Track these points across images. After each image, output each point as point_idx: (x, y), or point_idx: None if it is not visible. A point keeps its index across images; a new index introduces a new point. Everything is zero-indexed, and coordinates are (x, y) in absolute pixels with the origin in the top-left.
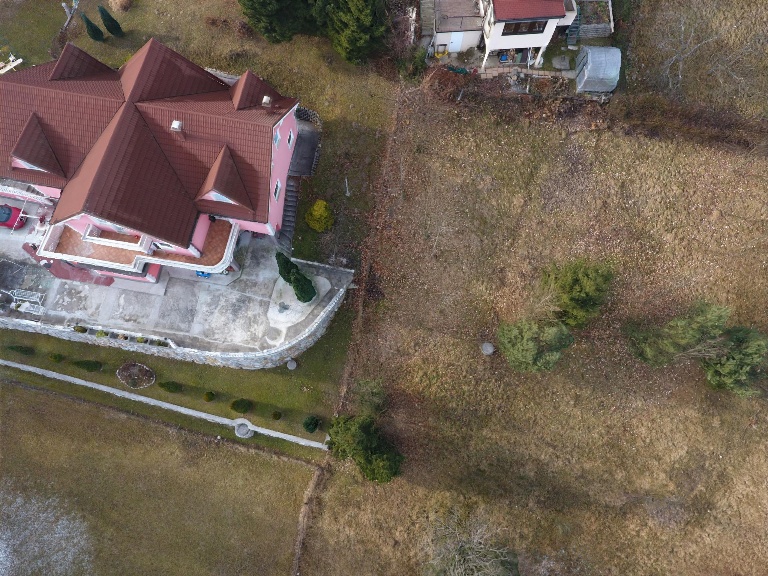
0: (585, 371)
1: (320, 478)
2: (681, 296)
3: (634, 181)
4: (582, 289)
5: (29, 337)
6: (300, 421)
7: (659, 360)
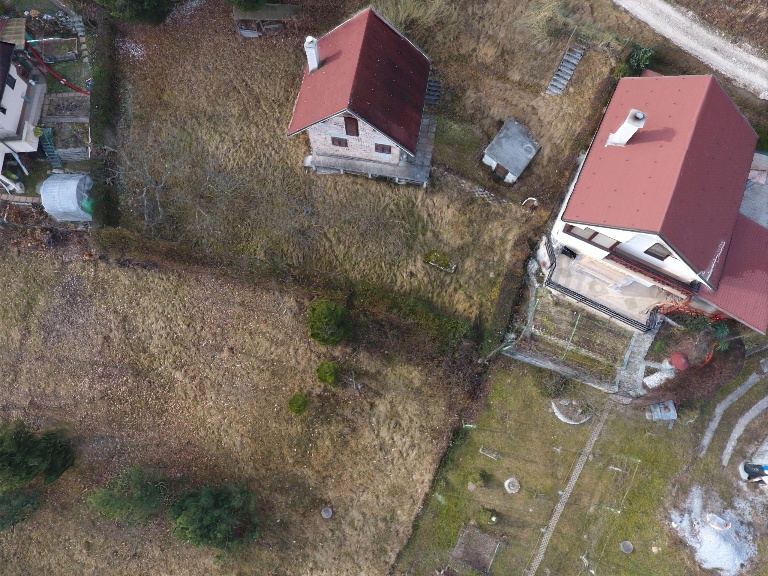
0: (96, 518)
1: None
2: (197, 438)
3: (136, 315)
4: None
5: None
6: None
7: None
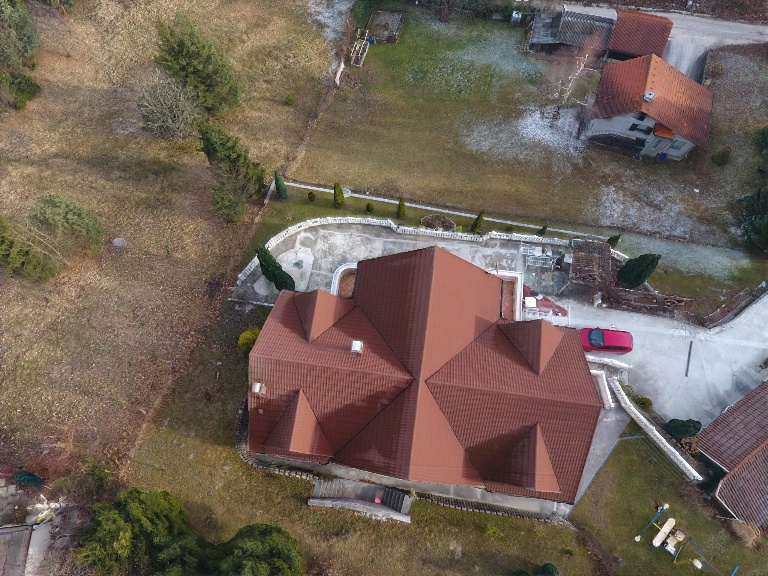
0: None
1: None
2: None
3: None
4: None
5: None
6: (295, 197)
7: None
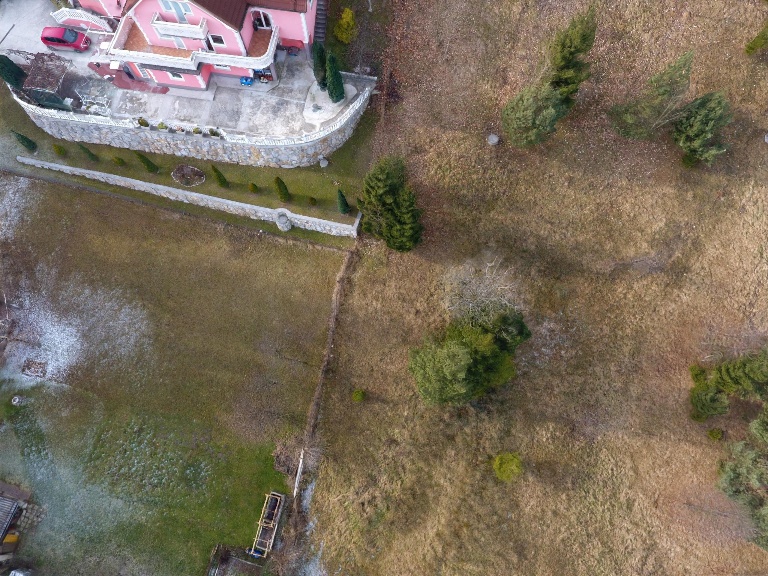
0: (577, 156)
1: (350, 261)
2: None
3: None
4: (572, 43)
5: (93, 148)
6: (332, 209)
7: (639, 131)
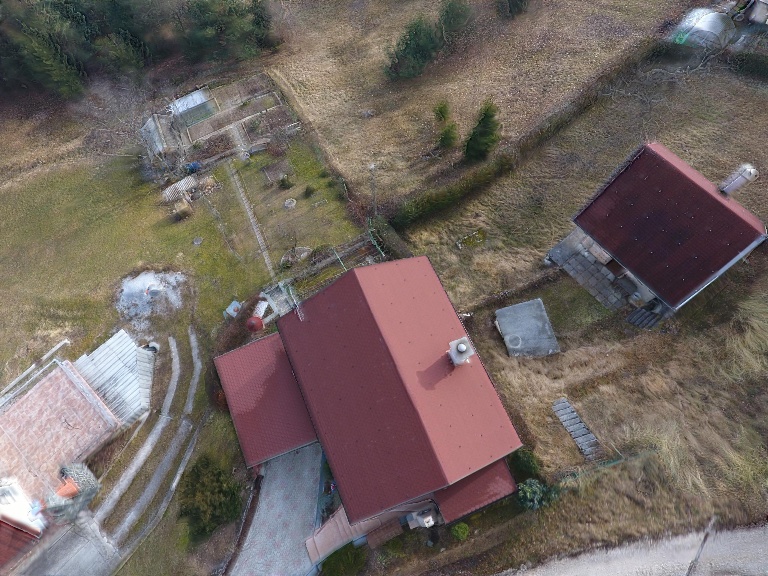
0: None
1: None
2: None
3: (584, 60)
4: None
5: None
6: None
7: None
